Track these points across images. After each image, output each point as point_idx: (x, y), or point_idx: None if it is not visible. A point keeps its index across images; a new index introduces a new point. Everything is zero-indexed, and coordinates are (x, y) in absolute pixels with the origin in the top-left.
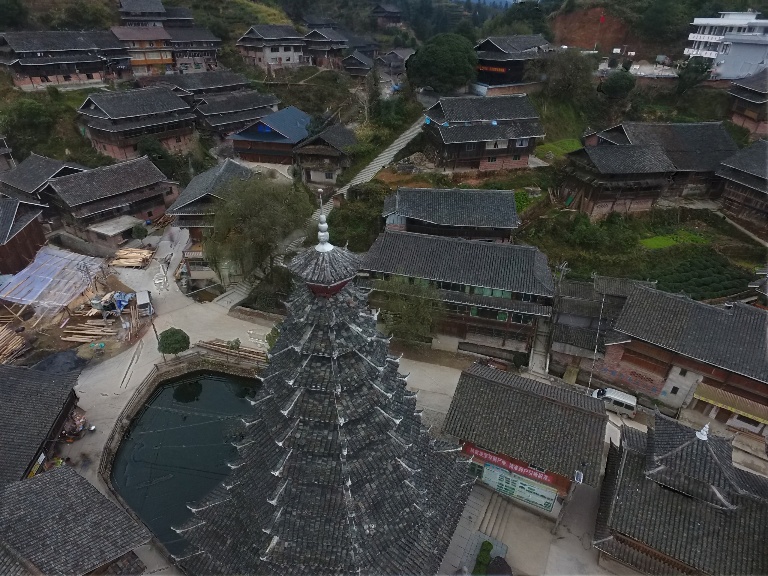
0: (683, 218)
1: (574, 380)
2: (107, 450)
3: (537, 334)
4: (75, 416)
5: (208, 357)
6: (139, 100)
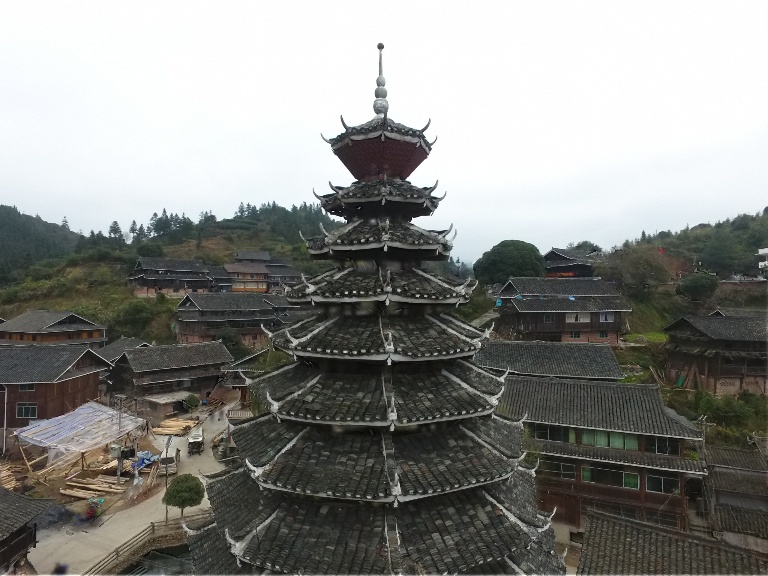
0: None
1: None
2: None
3: (691, 528)
4: (21, 572)
5: None
6: (229, 300)
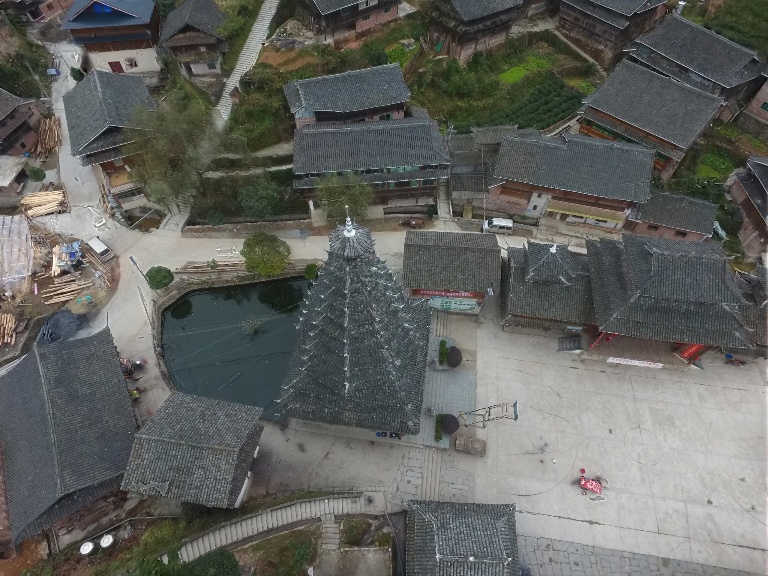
0: (530, 42)
1: (471, 216)
2: (162, 373)
3: None
4: None
5: (192, 280)
6: None
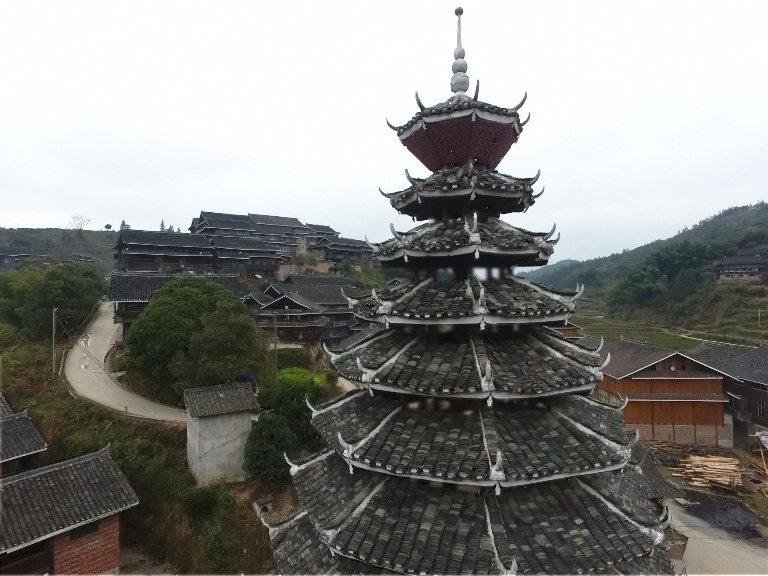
0: None
1: None
2: None
3: None
4: None
5: None
6: None
